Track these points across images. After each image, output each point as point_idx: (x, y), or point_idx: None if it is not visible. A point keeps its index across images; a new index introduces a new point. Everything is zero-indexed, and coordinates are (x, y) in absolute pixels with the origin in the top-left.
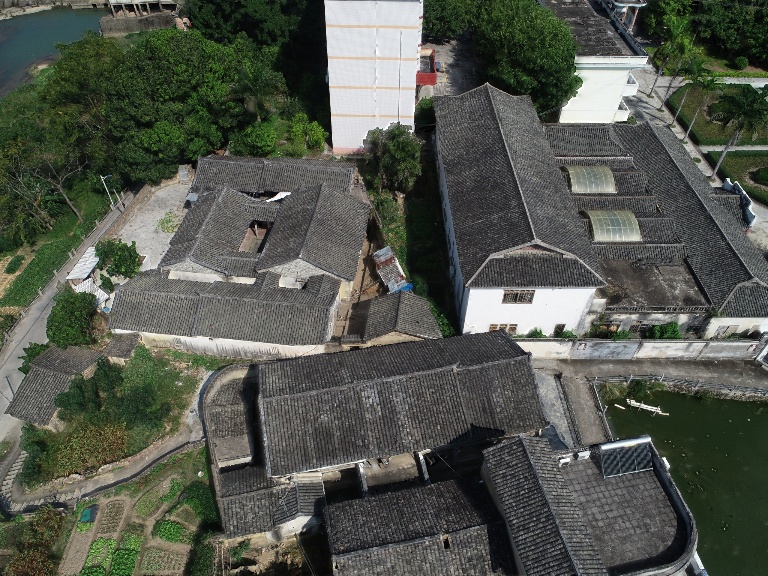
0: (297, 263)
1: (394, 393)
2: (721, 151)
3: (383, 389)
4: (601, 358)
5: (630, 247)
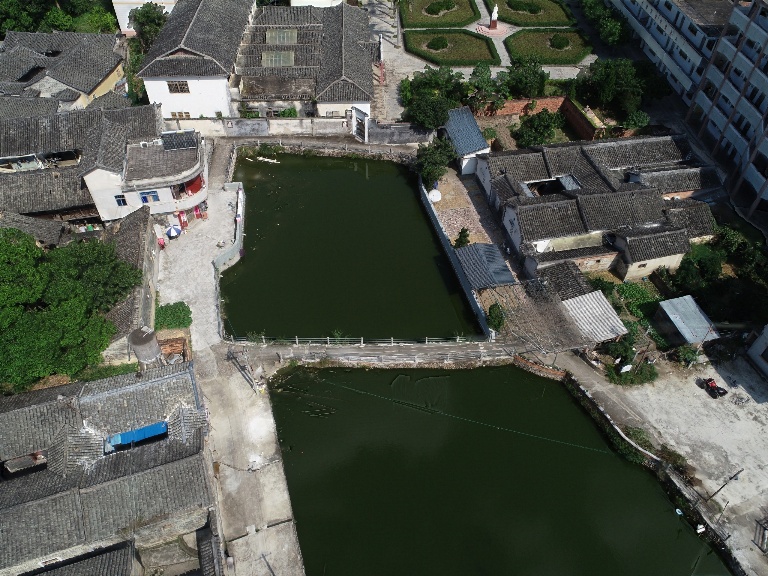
0: (47, 80)
1: (60, 121)
2: (414, 30)
3: (53, 118)
4: (248, 135)
5: (282, 69)
